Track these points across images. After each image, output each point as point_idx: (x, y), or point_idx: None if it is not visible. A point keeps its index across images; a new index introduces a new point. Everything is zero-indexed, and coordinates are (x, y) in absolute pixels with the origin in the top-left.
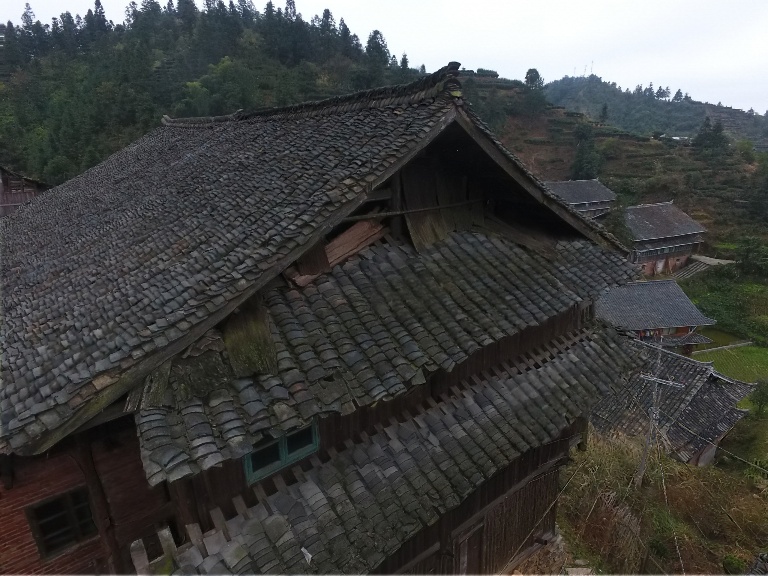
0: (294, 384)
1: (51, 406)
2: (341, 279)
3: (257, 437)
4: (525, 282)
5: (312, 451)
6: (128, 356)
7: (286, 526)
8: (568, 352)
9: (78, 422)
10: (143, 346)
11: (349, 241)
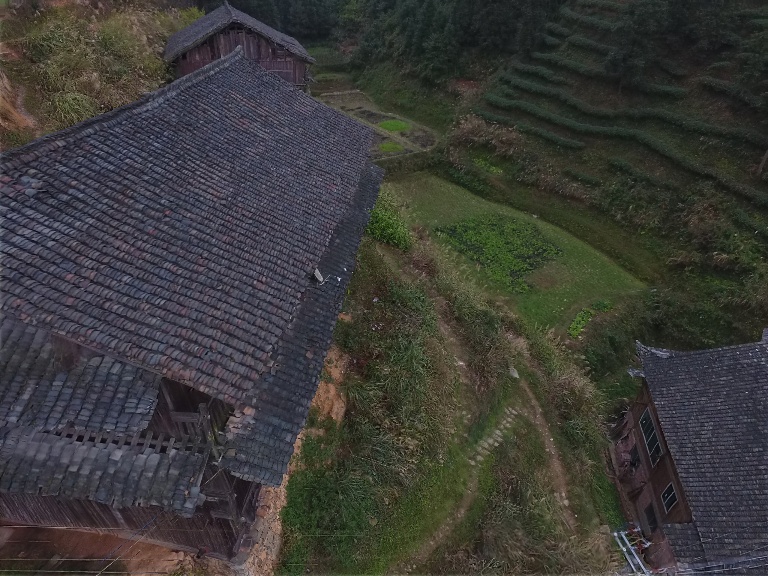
0: None
1: None
2: None
3: None
4: (1, 378)
5: None
6: None
7: None
8: (121, 447)
9: None
10: None
11: None
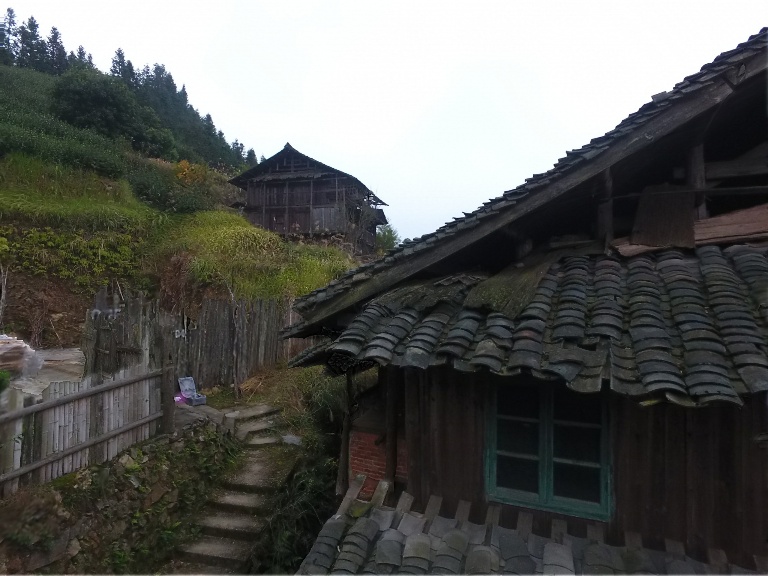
0: (523, 330)
1: (327, 287)
2: (708, 258)
3: (440, 361)
4: None
5: (597, 516)
6: (383, 260)
7: (491, 568)
8: None
9: (337, 307)
10: (396, 253)
11: (759, 221)
